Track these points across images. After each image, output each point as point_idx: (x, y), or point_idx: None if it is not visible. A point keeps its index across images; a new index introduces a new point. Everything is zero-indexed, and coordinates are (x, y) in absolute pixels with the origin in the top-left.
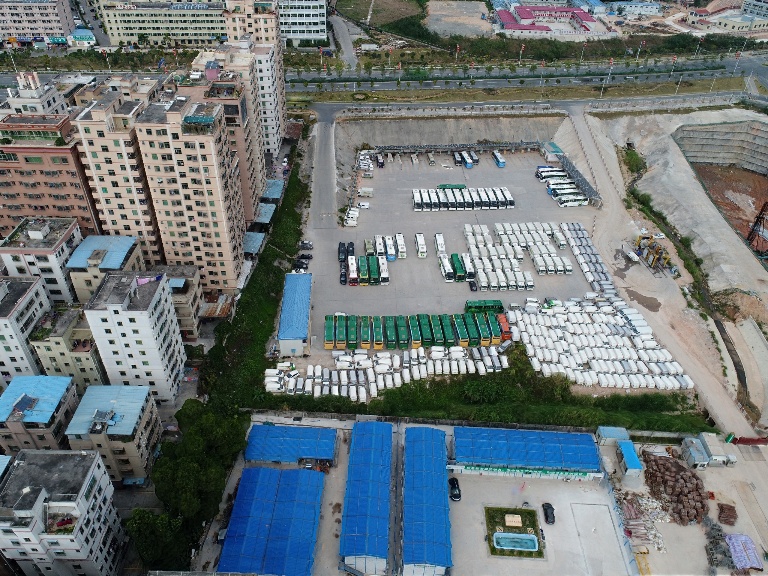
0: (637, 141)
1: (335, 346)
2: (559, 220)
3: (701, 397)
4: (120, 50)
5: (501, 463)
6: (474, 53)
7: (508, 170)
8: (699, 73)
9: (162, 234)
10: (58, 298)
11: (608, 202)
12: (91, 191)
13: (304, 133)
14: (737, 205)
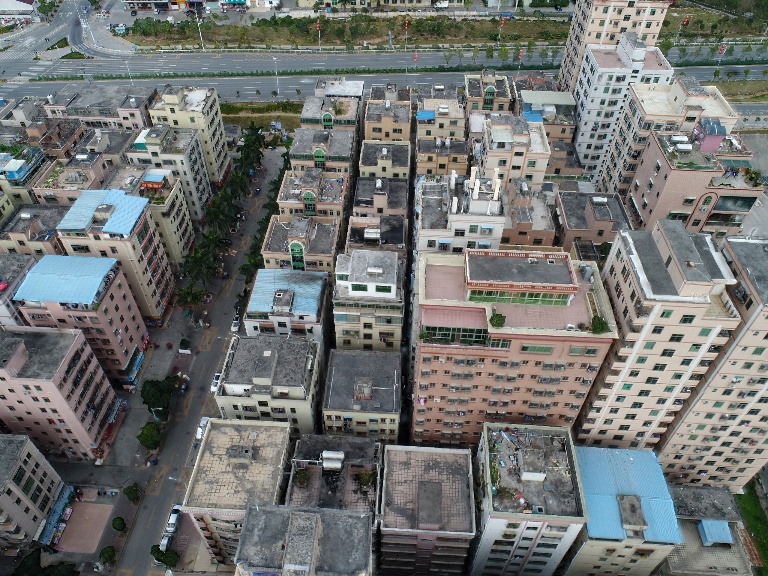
0: None
1: None
2: None
3: None
4: (324, 17)
5: None
6: (766, 17)
7: None
8: None
9: (676, 437)
10: (539, 559)
11: None
12: None
13: None
14: None
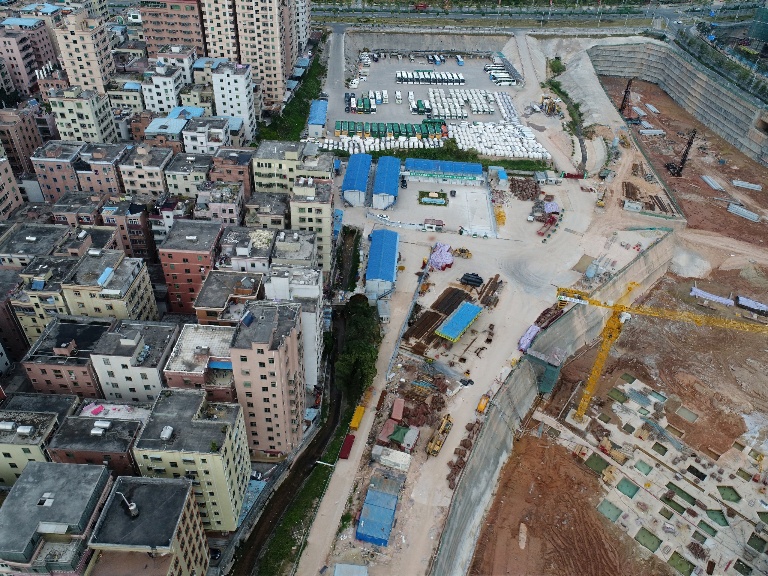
0: (563, 55)
1: (341, 134)
2: (494, 91)
3: (554, 163)
4: None
5: (429, 170)
6: None
7: (465, 67)
8: (622, 15)
9: (242, 60)
10: None
11: (530, 84)
12: (203, 31)
13: (323, 39)
14: None
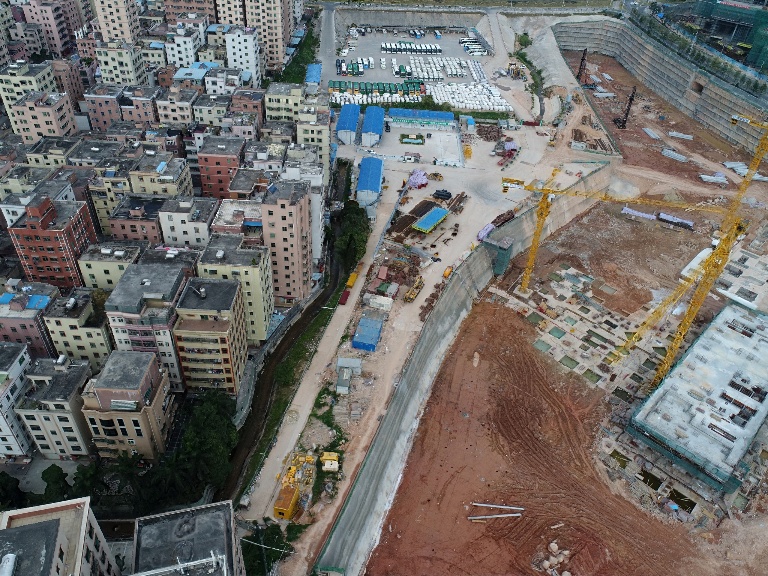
0: (530, 32)
1: (334, 91)
2: None
3: None
4: None
5: (409, 116)
6: None
7: (443, 40)
8: None
9: None
10: None
11: (499, 54)
12: (215, 1)
13: (315, 16)
14: (587, 68)
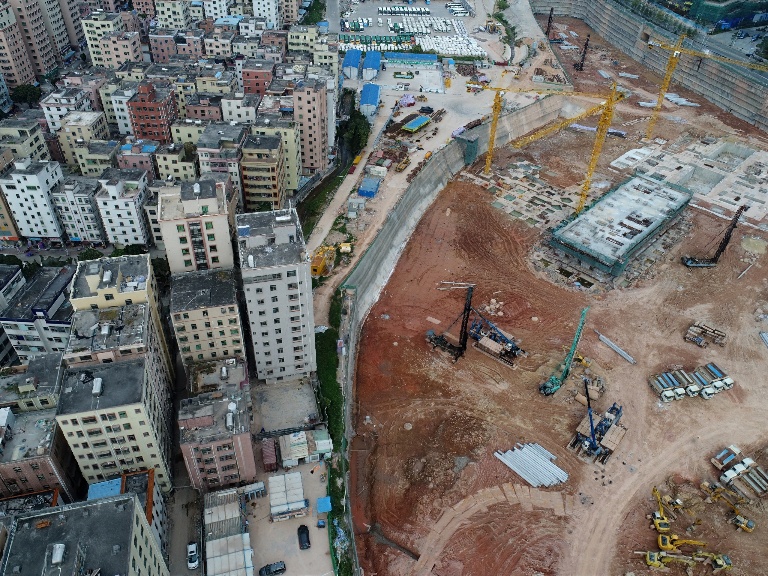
0: None
1: None
2: None
3: (489, 58)
4: None
5: None
6: None
7: (431, 5)
8: None
9: None
10: None
11: (479, 15)
12: None
13: None
14: (557, 28)
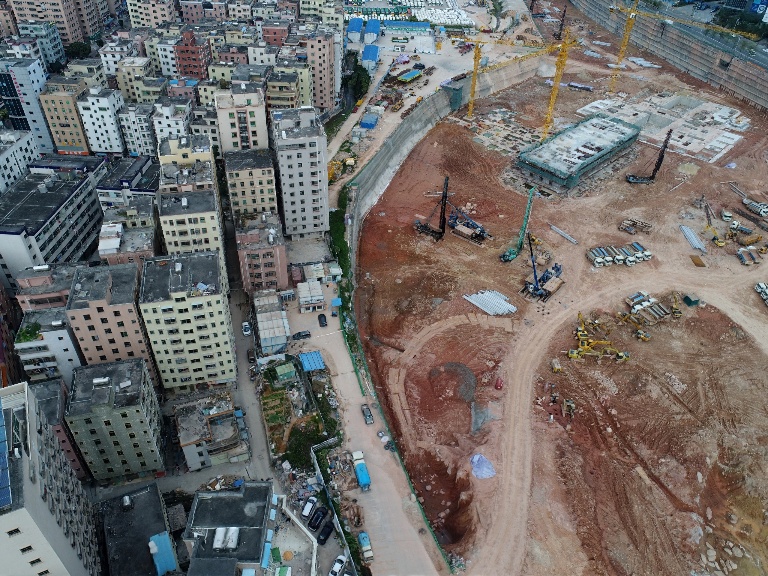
0: None
1: None
2: None
3: None
4: None
5: (398, 25)
6: None
7: None
8: None
9: None
10: None
11: None
12: None
13: None
14: (542, 4)
